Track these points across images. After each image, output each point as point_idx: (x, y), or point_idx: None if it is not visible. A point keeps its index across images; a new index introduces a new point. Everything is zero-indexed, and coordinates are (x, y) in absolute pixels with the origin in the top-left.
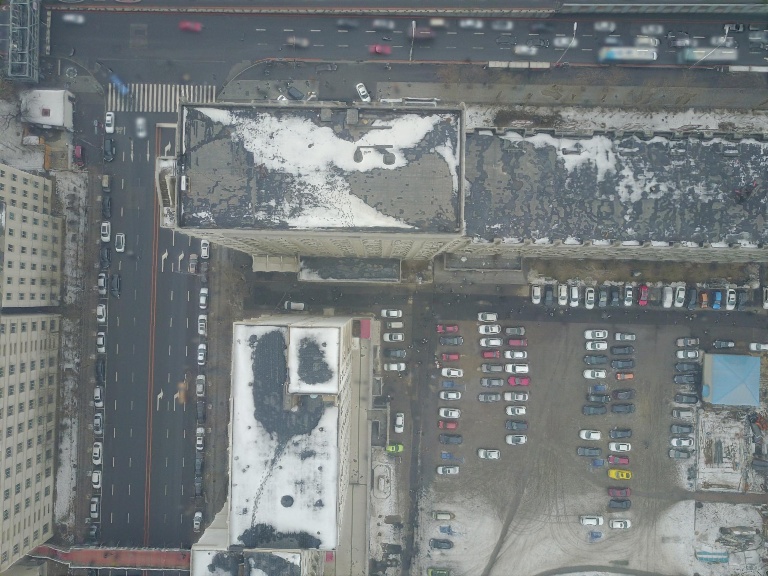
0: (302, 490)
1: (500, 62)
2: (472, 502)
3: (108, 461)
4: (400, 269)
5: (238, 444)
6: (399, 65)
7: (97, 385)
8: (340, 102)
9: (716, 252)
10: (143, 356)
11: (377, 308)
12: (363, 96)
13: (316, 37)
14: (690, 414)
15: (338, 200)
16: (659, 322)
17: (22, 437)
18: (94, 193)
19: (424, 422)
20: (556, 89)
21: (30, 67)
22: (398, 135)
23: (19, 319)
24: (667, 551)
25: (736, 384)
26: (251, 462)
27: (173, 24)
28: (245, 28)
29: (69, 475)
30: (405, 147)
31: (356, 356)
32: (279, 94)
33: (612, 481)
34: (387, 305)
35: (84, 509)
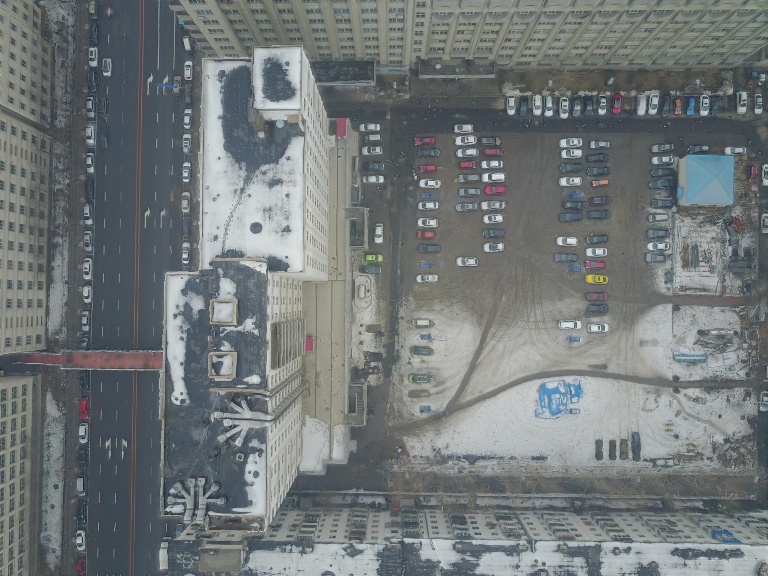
0: (270, 217)
1: None
2: (451, 310)
3: (98, 277)
4: (374, 71)
5: (208, 174)
6: None
7: (87, 203)
8: None
9: (678, 16)
10: (130, 176)
11: (355, 124)
12: None
13: None
14: (665, 217)
15: None
16: (633, 130)
17: (13, 236)
18: (82, 21)
19: (403, 233)
20: None
21: None
22: None
23: (9, 120)
24: (645, 354)
25: (709, 180)
26: (221, 191)
27: None
28: None
29: (61, 291)
30: None
31: (333, 157)
32: None
33: (589, 287)
34: (365, 120)
35: (76, 323)
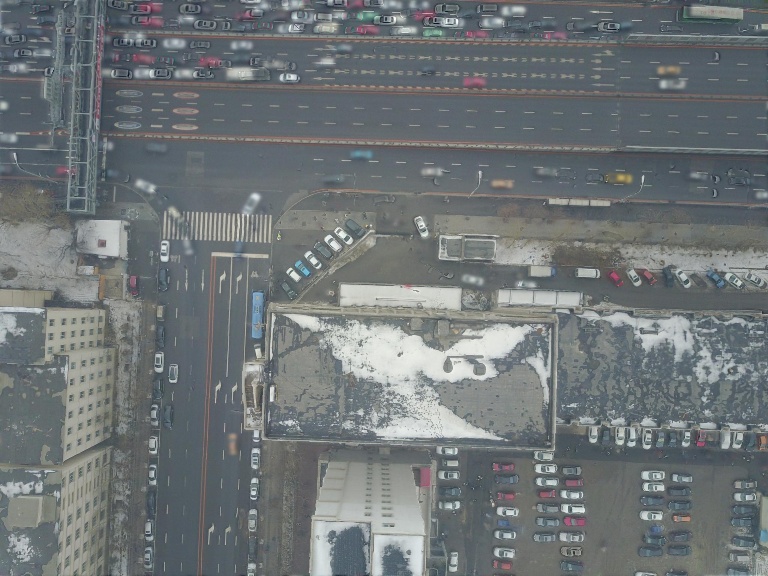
0: None
1: (560, 200)
2: None
3: None
4: None
5: None
6: (457, 198)
7: (148, 519)
8: (431, 312)
9: None
10: (195, 489)
11: None
12: (421, 230)
13: (374, 168)
14: (747, 559)
15: (427, 411)
16: (716, 463)
17: None
18: (148, 322)
19: (478, 561)
20: (615, 225)
21: (88, 201)
22: (489, 345)
23: (77, 466)
24: None
25: None
26: None
27: (230, 152)
28: (303, 158)
29: None
30: (496, 357)
31: None
32: (336, 225)
33: None
34: None
35: None
